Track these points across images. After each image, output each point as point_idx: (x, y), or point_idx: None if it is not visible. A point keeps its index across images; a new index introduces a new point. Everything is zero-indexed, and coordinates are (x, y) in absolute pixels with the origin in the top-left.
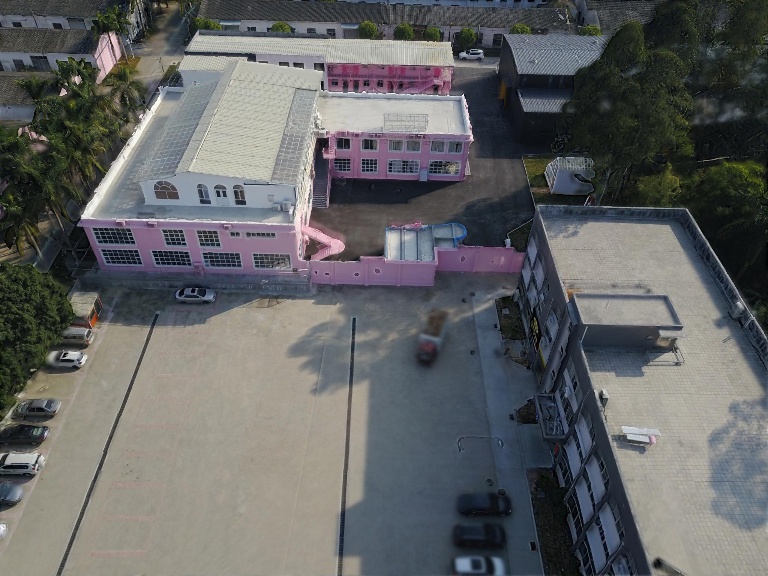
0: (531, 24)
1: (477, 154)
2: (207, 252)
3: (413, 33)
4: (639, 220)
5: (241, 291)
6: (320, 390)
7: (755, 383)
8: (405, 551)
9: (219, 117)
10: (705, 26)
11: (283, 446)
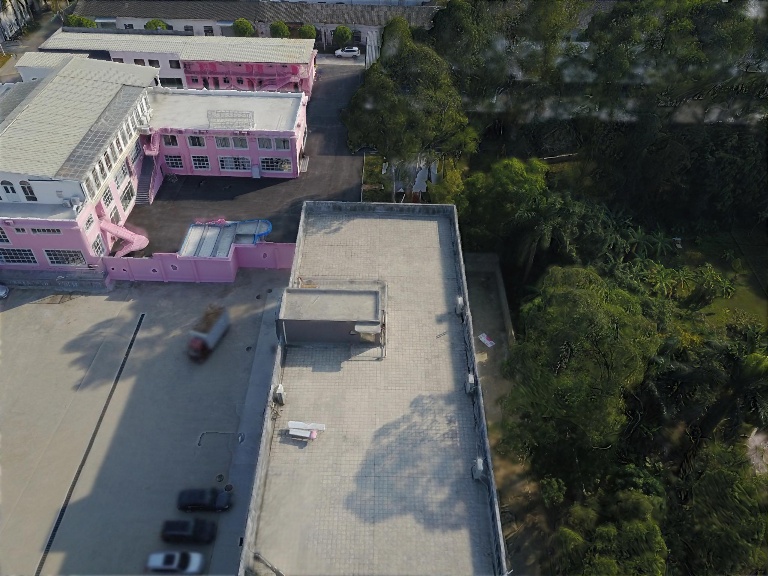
0: None
1: (320, 151)
2: None
3: (288, 30)
4: (409, 216)
5: (37, 287)
6: (83, 386)
7: (449, 378)
8: (113, 546)
9: (27, 113)
10: (497, 22)
11: (26, 442)
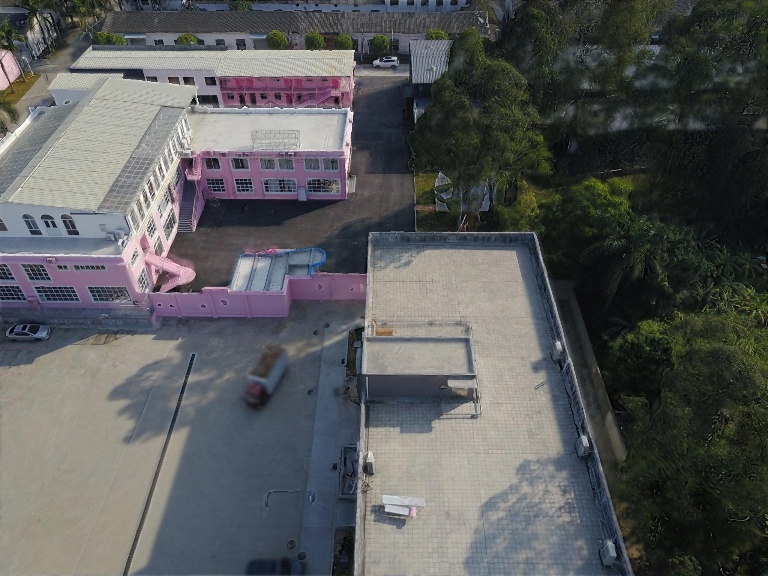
0: (448, 28)
1: (367, 169)
2: (39, 286)
3: (324, 41)
4: (483, 246)
5: (80, 326)
6: (135, 438)
7: (556, 438)
8: None
9: (64, 140)
10: (569, 30)
11: (78, 503)
